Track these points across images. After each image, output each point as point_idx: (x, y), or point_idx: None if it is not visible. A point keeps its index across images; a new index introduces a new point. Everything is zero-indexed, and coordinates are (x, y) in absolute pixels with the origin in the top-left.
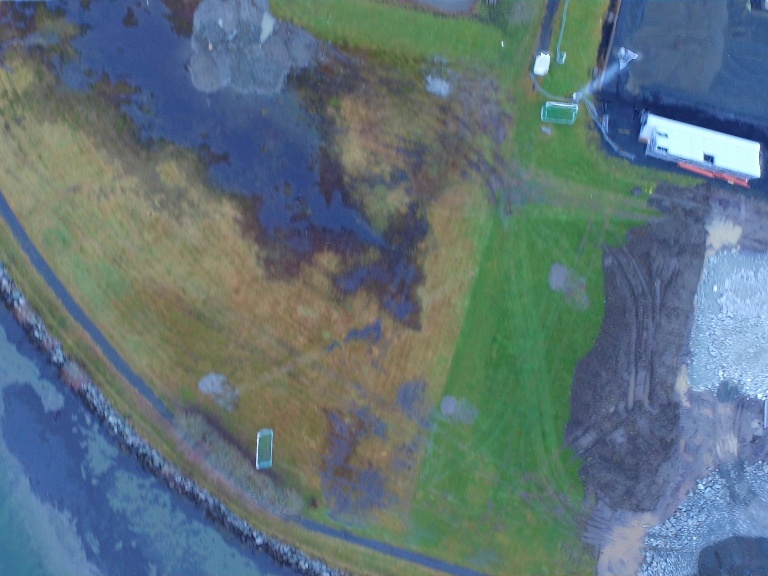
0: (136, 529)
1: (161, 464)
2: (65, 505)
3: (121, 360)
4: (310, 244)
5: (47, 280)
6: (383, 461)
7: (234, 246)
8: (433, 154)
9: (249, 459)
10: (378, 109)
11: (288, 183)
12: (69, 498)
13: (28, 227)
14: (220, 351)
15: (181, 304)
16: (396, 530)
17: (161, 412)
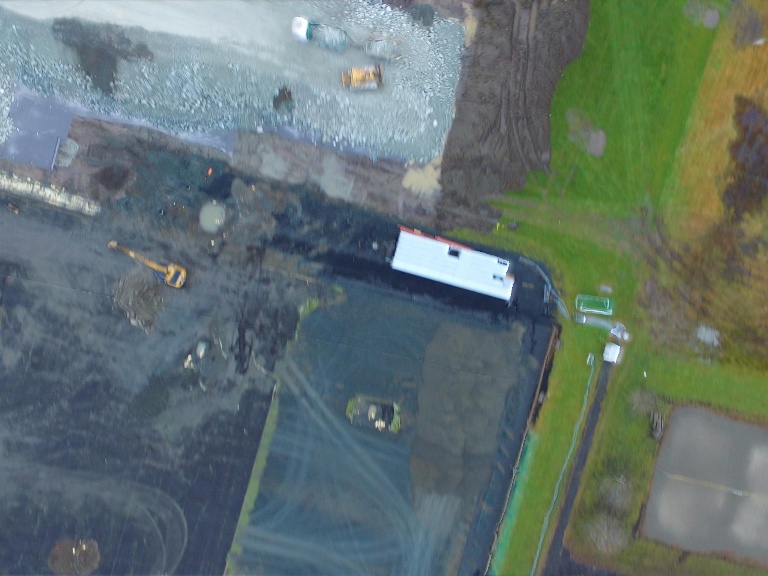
0: None
1: None
2: None
3: None
4: None
5: None
6: None
7: None
8: (716, 269)
9: None
10: (767, 314)
11: None
12: None
13: None
14: None
15: None
16: None
17: None
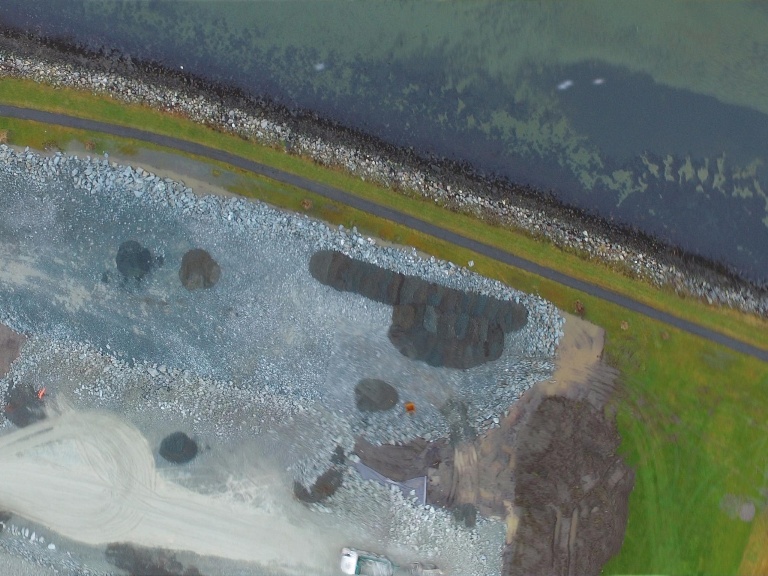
0: None
1: None
2: None
3: None
4: None
5: None
6: None
7: None
8: None
9: None
10: None
11: None
12: None
13: None
14: None
15: None
16: None
17: None
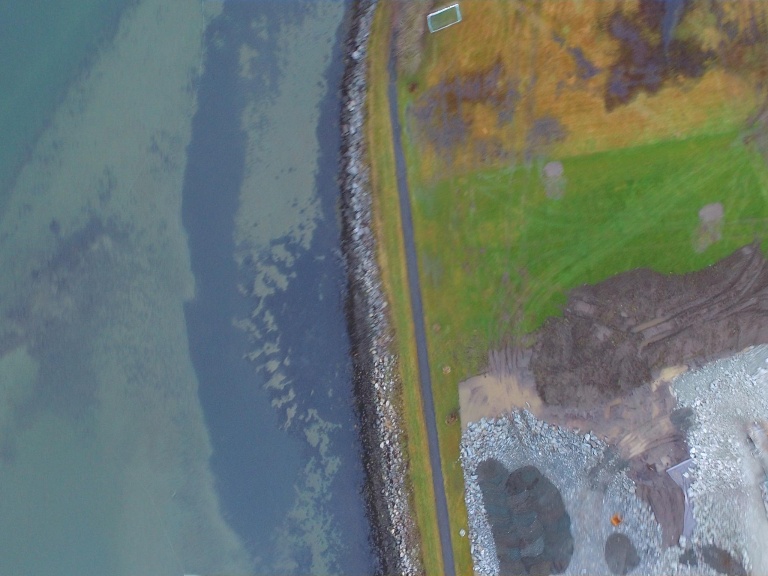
0: None
1: None
2: None
3: None
4: None
5: None
6: (478, 133)
7: None
8: (764, 51)
9: (434, 4)
10: None
11: None
12: None
13: None
14: None
15: None
16: (422, 174)
17: None
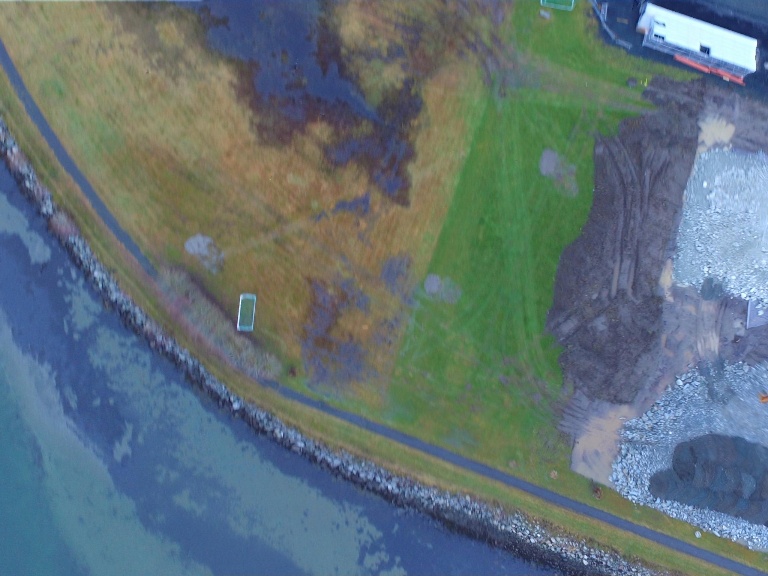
0: (115, 387)
1: (143, 322)
2: (46, 357)
3: (110, 215)
4: (304, 113)
5: (41, 130)
6: (364, 334)
7: (228, 110)
8: (431, 32)
9: (230, 319)
10: None
11: (285, 51)
12: (50, 351)
13: (25, 76)
14: (208, 213)
15: (172, 163)
16: (373, 404)
17: (146, 269)
